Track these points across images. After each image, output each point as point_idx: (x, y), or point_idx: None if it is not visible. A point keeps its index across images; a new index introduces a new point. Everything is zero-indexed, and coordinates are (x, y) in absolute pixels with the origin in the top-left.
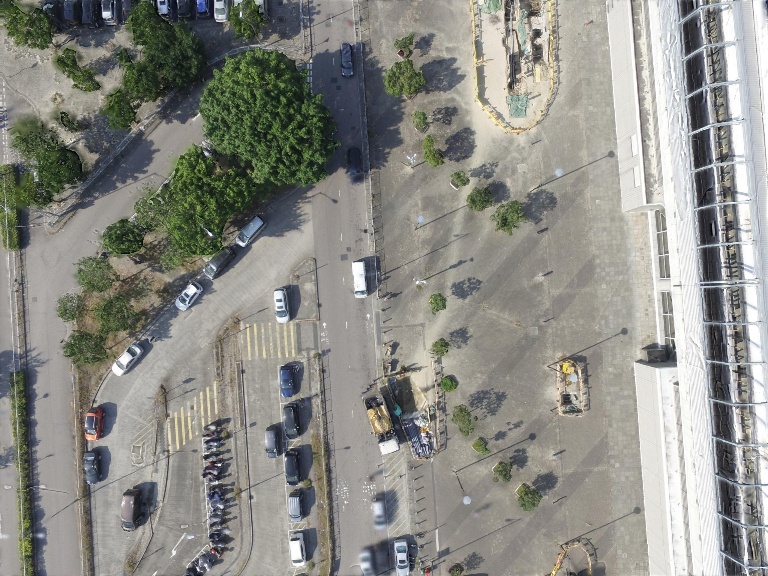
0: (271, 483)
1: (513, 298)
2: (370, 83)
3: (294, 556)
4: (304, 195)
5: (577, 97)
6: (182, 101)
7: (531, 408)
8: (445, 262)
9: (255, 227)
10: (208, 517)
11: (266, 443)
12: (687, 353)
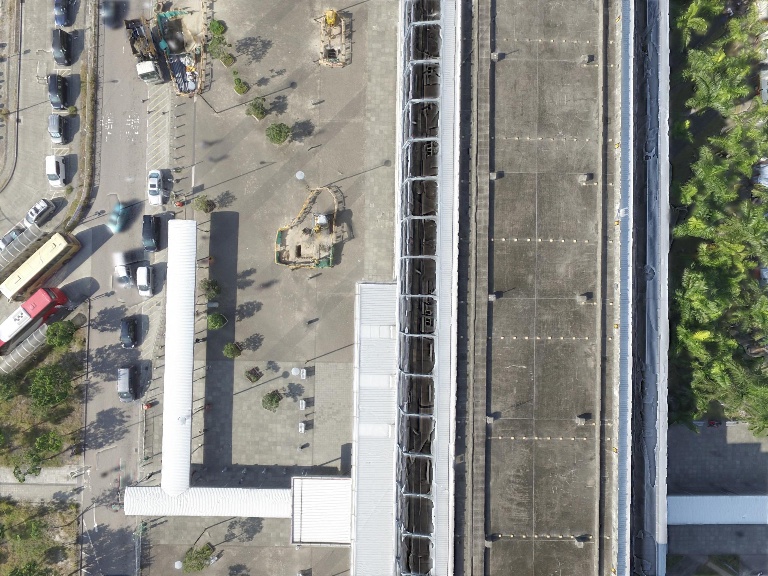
0: (39, 109)
1: None
2: None
3: (49, 171)
4: None
5: None
6: None
7: (295, 58)
8: None
9: None
10: None
11: (38, 70)
12: None
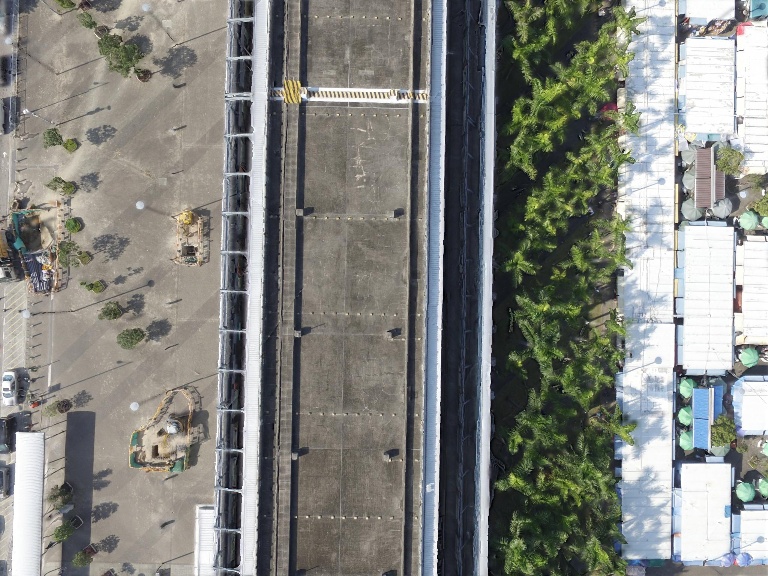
0: None
1: (146, 148)
2: None
3: None
4: None
5: None
6: None
7: (152, 256)
8: (83, 108)
9: None
10: None
11: None
12: None
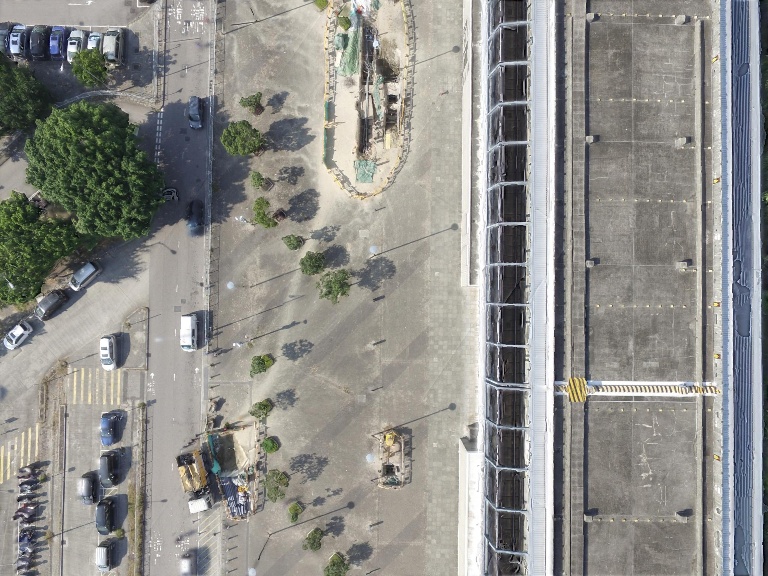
0: (85, 530)
1: (343, 364)
2: (219, 137)
3: None
4: (143, 243)
5: (425, 167)
6: None
7: (352, 476)
8: (278, 322)
9: (86, 273)
10: (17, 559)
11: (83, 489)
12: None
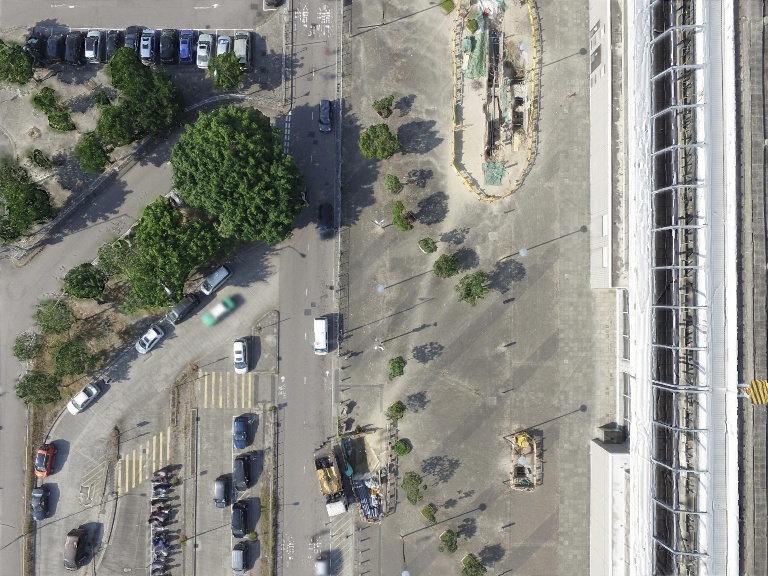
0: (217, 533)
1: (474, 366)
2: (347, 140)
3: None
4: (272, 247)
5: (554, 169)
6: (158, 144)
7: (484, 478)
8: (408, 325)
9: (220, 277)
10: (151, 563)
11: (215, 493)
12: (639, 444)
